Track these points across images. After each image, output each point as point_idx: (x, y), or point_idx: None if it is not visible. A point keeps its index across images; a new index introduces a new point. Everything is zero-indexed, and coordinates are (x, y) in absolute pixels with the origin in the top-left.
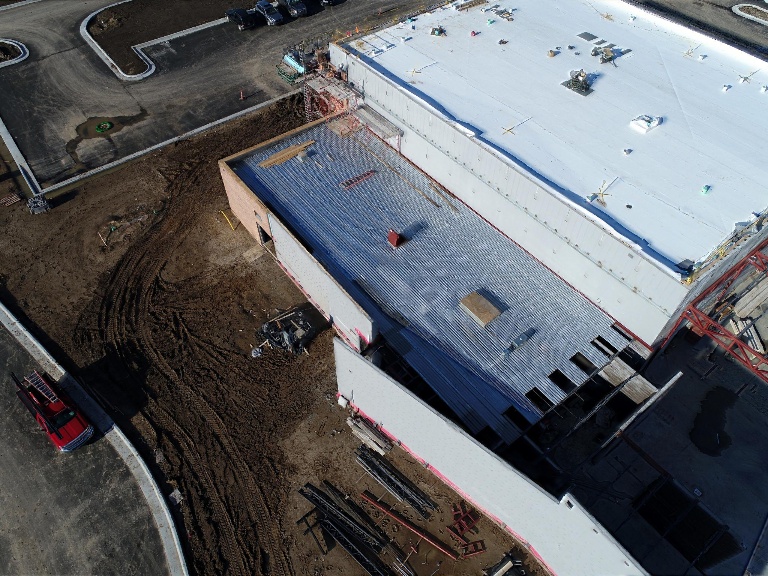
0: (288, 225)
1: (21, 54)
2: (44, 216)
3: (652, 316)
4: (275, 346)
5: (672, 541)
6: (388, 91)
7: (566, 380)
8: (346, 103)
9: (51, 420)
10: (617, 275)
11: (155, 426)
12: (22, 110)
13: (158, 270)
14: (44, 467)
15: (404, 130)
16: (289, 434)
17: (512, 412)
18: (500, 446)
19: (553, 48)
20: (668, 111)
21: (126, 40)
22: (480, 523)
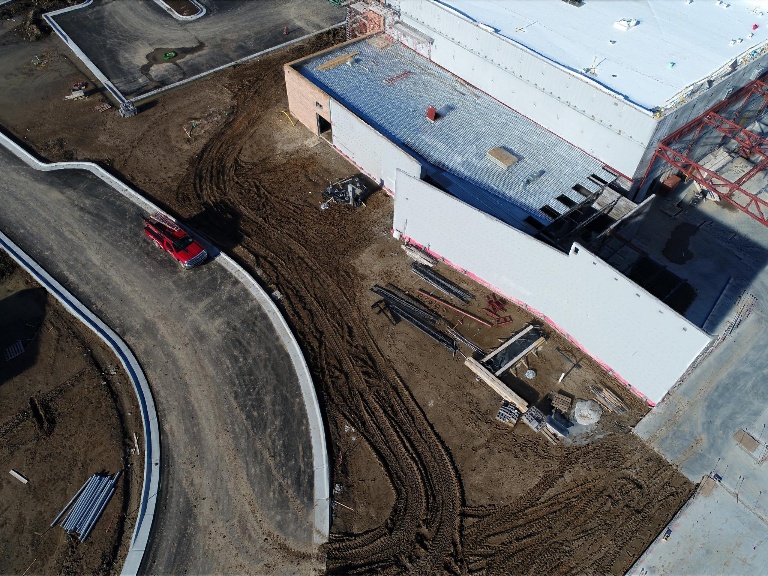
0: None
1: None
2: (134, 118)
3: (632, 152)
4: (339, 201)
5: None
6: (422, 5)
7: (569, 201)
8: (383, 23)
9: (177, 242)
10: (606, 124)
11: (253, 253)
12: (97, 43)
13: (236, 154)
14: (172, 279)
15: (434, 38)
16: (358, 256)
17: (530, 220)
18: None
19: None
20: (644, 16)
21: None
22: (507, 306)
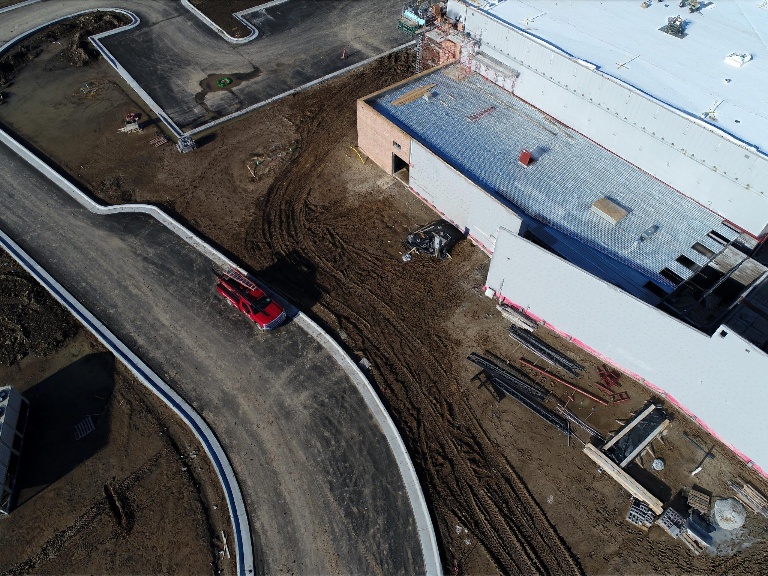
0: None
1: (133, 21)
2: (192, 154)
3: (762, 209)
4: (422, 252)
5: None
6: (509, 36)
7: (690, 263)
8: (459, 52)
9: (255, 303)
10: (731, 176)
11: (334, 313)
12: (147, 68)
13: (305, 196)
14: (248, 343)
15: (521, 71)
16: (449, 317)
17: (650, 285)
18: None
19: (645, 1)
20: (756, 50)
21: (226, 8)
22: (622, 380)
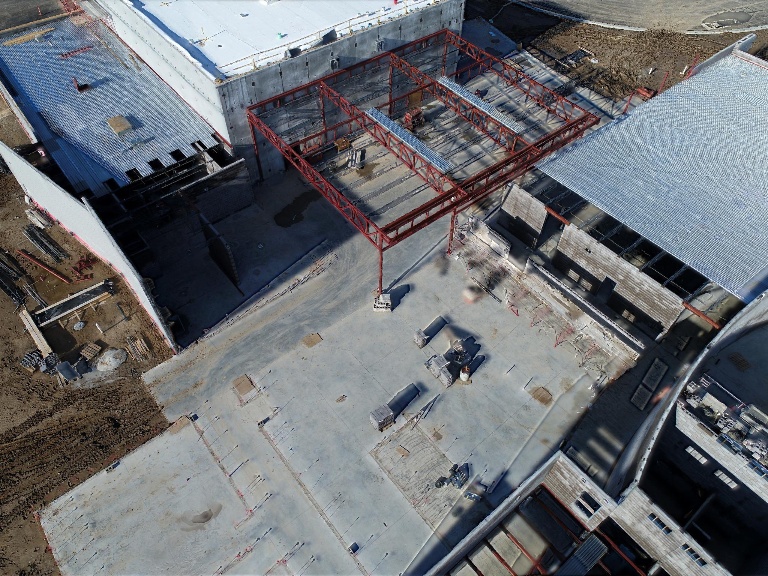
0: (6, 80)
1: None
2: None
3: (221, 118)
4: None
5: (224, 270)
6: None
7: (161, 165)
8: None
9: None
10: (201, 91)
11: None
12: None
13: None
14: None
15: (111, 14)
16: None
17: (111, 182)
18: (91, 199)
19: None
20: None
21: None
22: (96, 265)
